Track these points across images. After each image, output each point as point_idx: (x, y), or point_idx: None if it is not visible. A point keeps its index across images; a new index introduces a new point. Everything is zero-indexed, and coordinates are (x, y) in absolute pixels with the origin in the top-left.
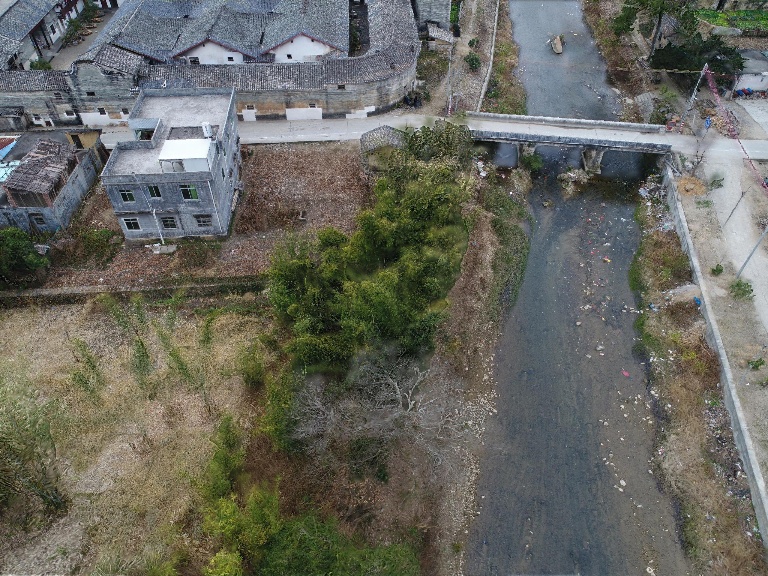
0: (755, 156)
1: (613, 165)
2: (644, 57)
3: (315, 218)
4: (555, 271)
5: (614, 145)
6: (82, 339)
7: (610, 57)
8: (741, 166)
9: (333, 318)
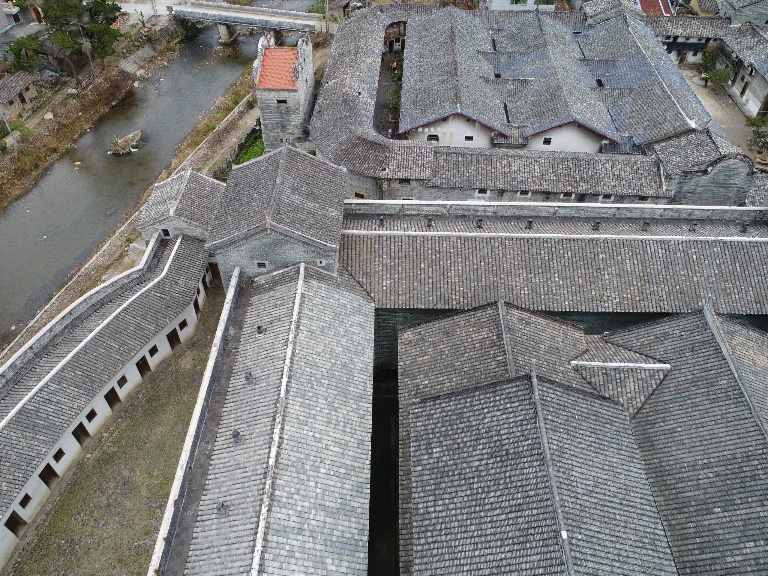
0: (133, 4)
1: (215, 36)
2: (73, 89)
3: (431, 5)
4: (302, 1)
5: (223, 8)
6: None
7: (90, 117)
8: (149, 3)
9: None
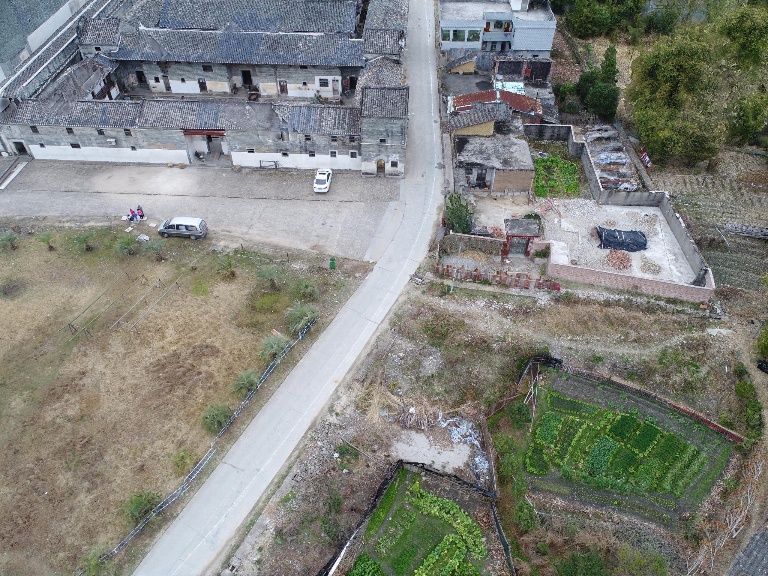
0: None
1: None
2: None
3: None
4: None
5: None
6: (623, 86)
7: None
8: None
9: (618, 2)
